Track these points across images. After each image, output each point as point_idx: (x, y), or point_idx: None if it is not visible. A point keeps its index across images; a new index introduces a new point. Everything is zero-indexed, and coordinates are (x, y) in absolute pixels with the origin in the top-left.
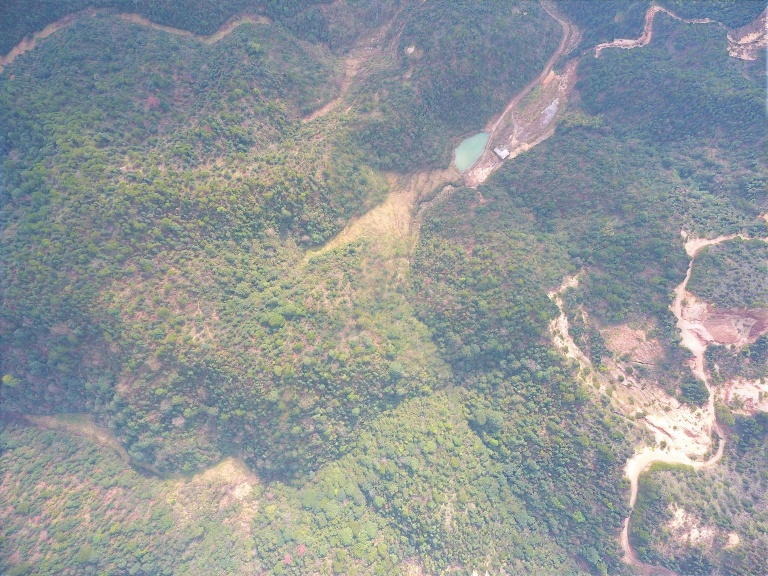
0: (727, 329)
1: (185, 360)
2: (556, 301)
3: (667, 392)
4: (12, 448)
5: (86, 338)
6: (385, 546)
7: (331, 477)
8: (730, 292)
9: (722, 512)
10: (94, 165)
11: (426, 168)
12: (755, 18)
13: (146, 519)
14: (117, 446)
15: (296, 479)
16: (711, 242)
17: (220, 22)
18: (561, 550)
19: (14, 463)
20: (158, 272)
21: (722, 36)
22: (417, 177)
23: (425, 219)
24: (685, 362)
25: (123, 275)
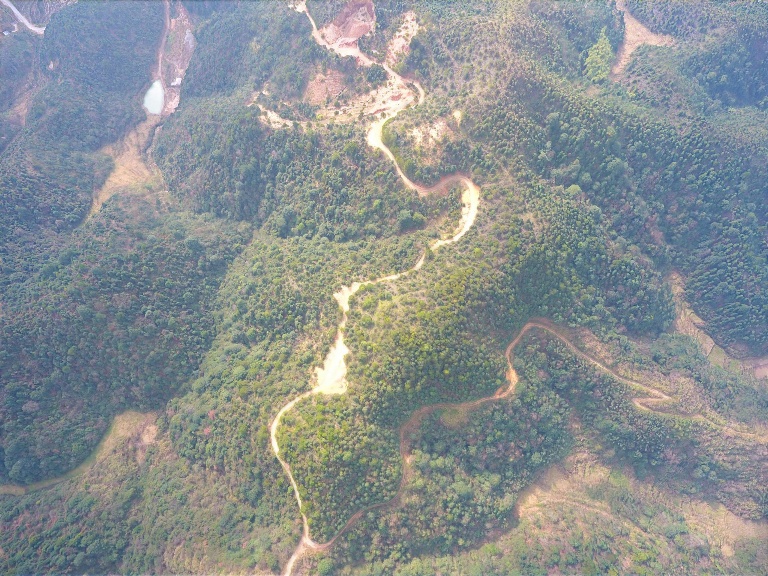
0: (356, 25)
1: None
2: None
3: (365, 92)
4: None
5: None
6: None
7: (211, 359)
8: (334, 4)
9: None
10: None
11: (129, 128)
12: None
13: None
14: (4, 490)
15: (182, 384)
16: None
17: None
18: (392, 238)
19: None
20: None
21: None
22: (128, 138)
23: (154, 156)
24: (357, 66)
25: None
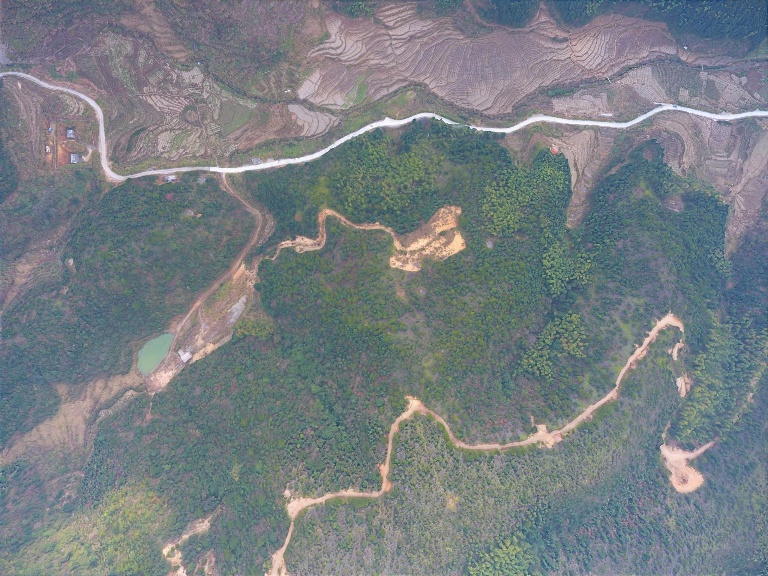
0: None
1: None
2: (174, 554)
3: None
4: None
5: None
6: None
7: None
8: (309, 572)
9: None
10: None
11: (102, 376)
12: (424, 223)
13: None
14: None
15: None
16: (316, 501)
17: None
18: None
19: None
20: None
21: (383, 247)
22: (94, 385)
23: (98, 431)
24: None
25: None
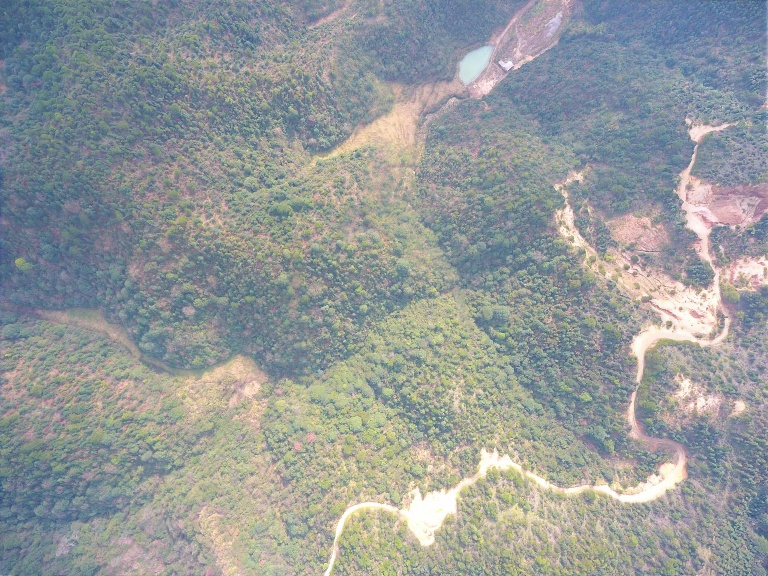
0: (732, 209)
1: (195, 243)
2: (562, 193)
3: (672, 277)
4: (25, 337)
5: (97, 220)
6: (394, 433)
7: (339, 374)
8: (735, 171)
9: (728, 382)
10: (104, 46)
11: (431, 79)
12: None
13: (157, 410)
14: (128, 343)
15: (305, 376)
16: (715, 129)
17: None
18: (568, 433)
19: (27, 351)
20: (168, 158)
21: None
22: (422, 89)
23: (430, 129)
24: (690, 246)
25: (134, 157)
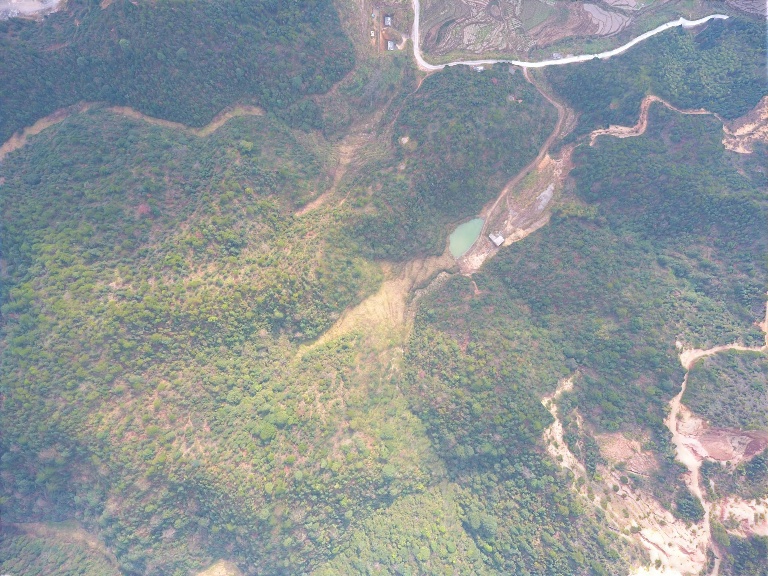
0: (722, 446)
1: (175, 478)
2: (550, 407)
3: (662, 505)
4: (0, 561)
5: (75, 457)
6: None
7: None
8: (725, 411)
9: None
10: (83, 286)
11: (420, 256)
12: (751, 109)
13: None
14: (107, 551)
15: None
16: (706, 353)
17: (213, 114)
18: None
19: None
20: (148, 388)
21: (718, 129)
22: (411, 265)
23: (419, 308)
24: (680, 476)
25: (112, 395)
